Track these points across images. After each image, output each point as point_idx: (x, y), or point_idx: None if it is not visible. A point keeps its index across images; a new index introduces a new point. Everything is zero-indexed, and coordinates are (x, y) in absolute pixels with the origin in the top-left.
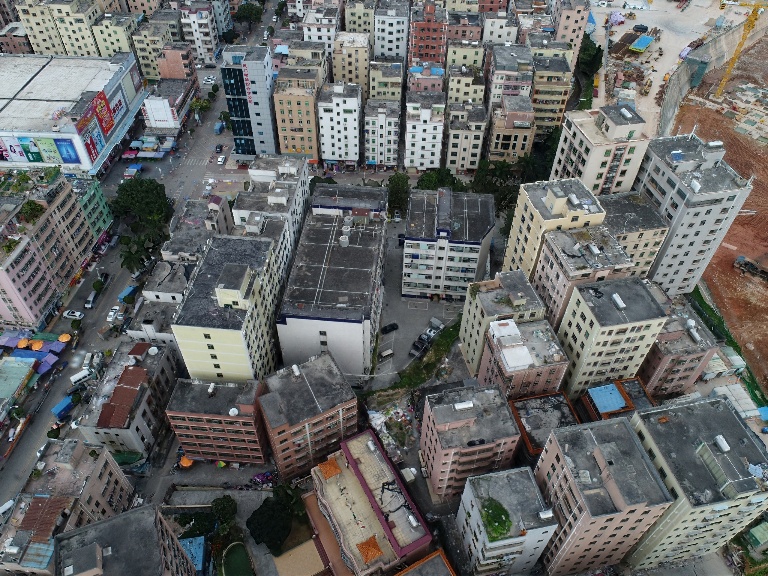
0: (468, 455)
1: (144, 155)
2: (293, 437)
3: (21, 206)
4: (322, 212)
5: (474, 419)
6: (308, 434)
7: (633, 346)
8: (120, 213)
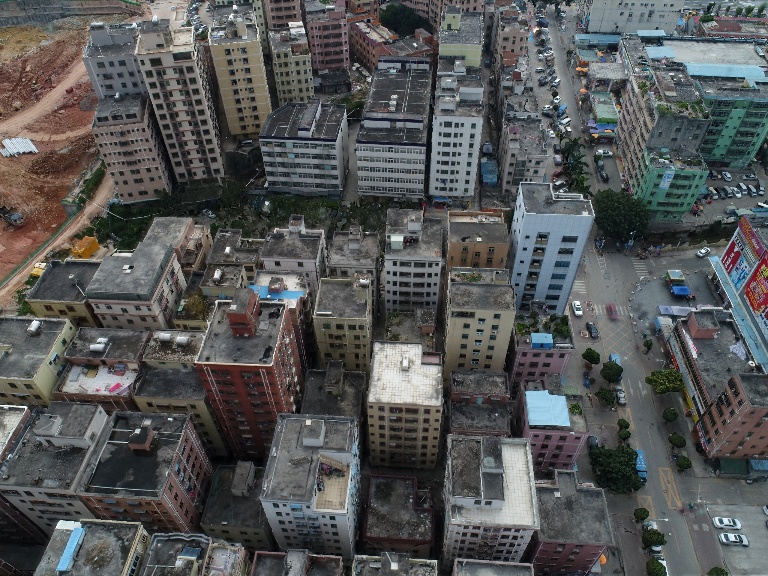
0: None
1: None
2: None
3: None
4: None
5: None
6: None
7: None
8: None
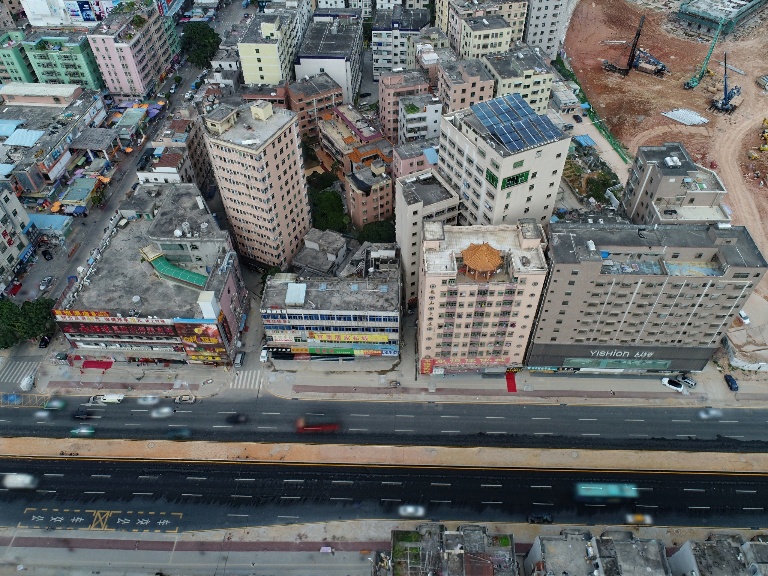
0: (401, 95)
1: (195, 20)
2: (307, 108)
3: (133, 17)
4: (320, 20)
5: (403, 76)
6: (315, 109)
7: (496, 51)
8: (185, 44)
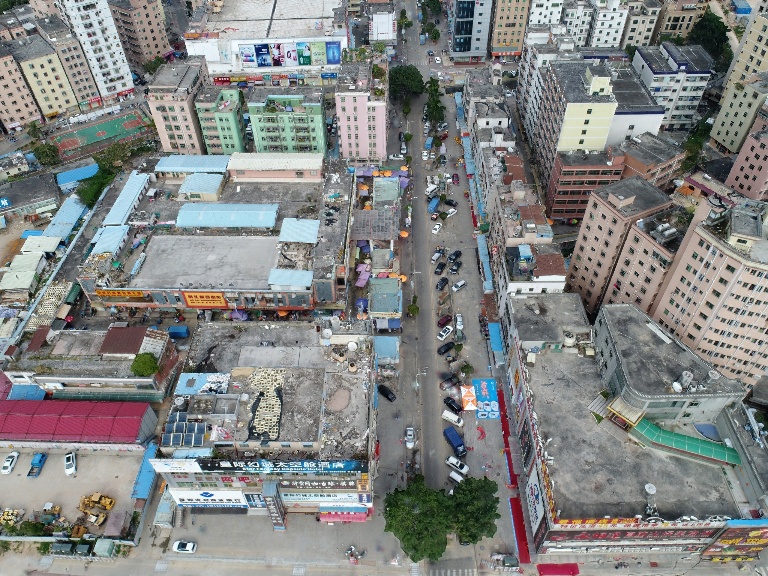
0: None
1: None
2: None
3: (372, 67)
4: None
5: None
6: (655, 179)
7: None
8: (395, 92)
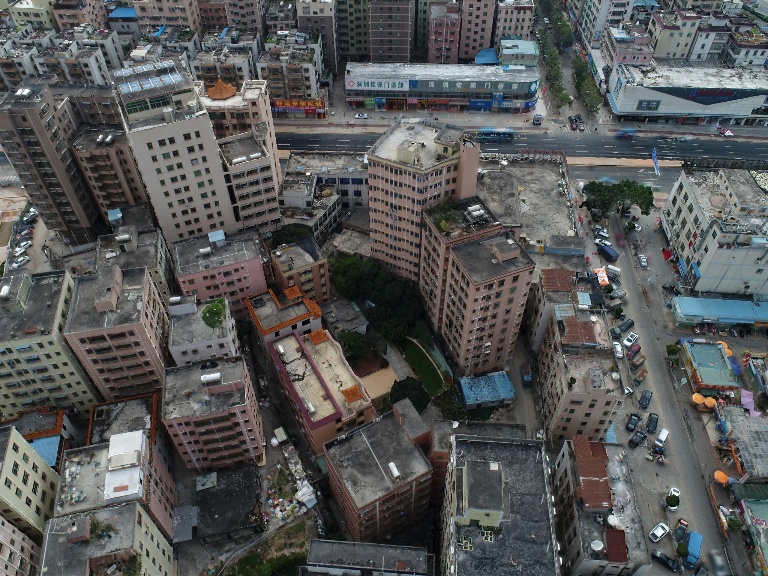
0: None
1: None
2: None
3: None
4: None
5: None
6: None
7: None
8: None
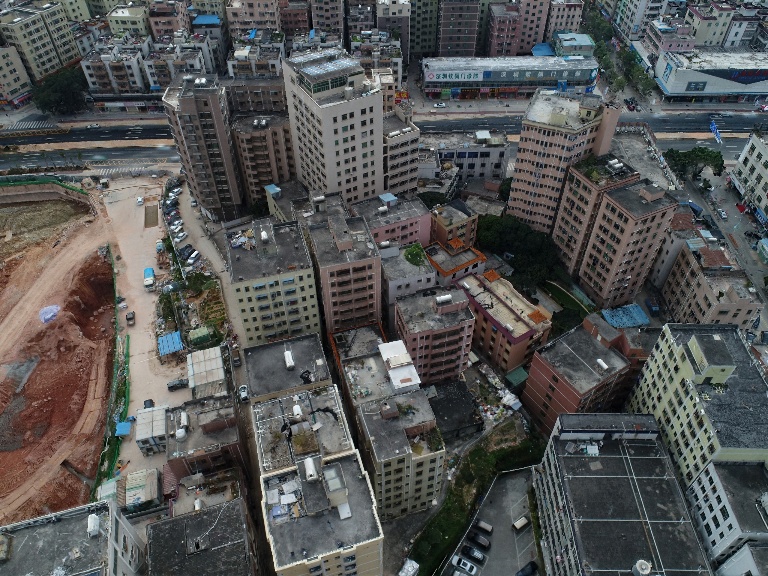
0: None
1: None
2: None
3: None
4: None
5: None
6: None
7: None
8: None
